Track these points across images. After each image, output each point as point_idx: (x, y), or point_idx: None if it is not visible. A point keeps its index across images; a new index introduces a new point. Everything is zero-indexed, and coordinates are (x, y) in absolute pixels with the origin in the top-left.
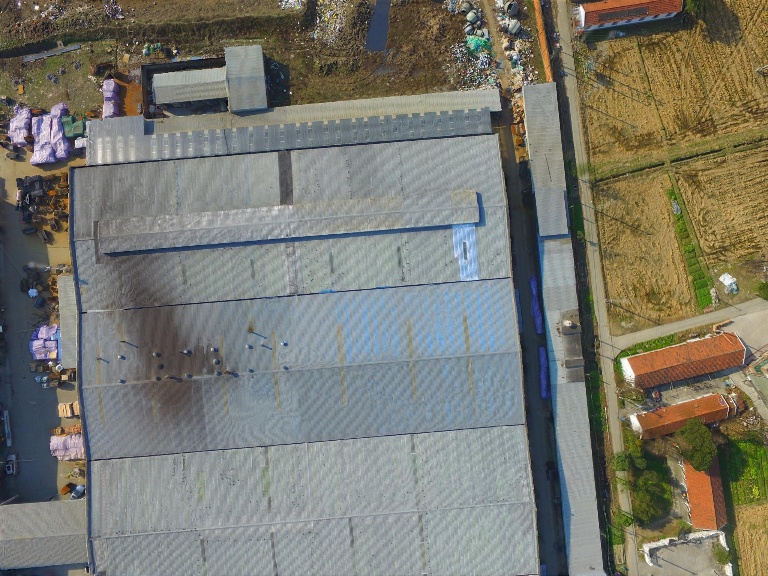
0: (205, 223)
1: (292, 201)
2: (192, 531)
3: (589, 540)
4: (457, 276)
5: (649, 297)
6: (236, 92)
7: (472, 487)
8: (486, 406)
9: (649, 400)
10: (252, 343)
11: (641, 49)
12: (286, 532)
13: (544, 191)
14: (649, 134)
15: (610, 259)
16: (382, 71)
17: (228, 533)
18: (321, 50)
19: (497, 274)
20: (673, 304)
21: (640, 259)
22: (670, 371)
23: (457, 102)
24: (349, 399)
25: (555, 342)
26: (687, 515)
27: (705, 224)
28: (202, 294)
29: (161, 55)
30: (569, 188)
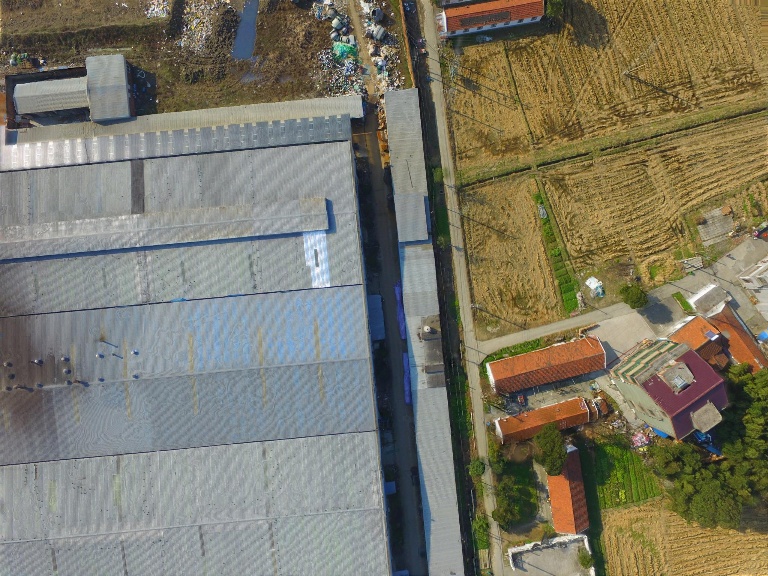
0: (54, 233)
1: (143, 210)
2: (42, 540)
3: (450, 545)
4: (309, 283)
5: (515, 301)
6: (97, 101)
7: (322, 494)
8: (337, 413)
9: (515, 404)
10: (103, 352)
11: (508, 53)
12: (136, 540)
13: (403, 197)
14: (516, 138)
15: (476, 264)
16: (249, 78)
17: (79, 542)
18: (188, 58)
19: (349, 281)
20: (539, 308)
21: (506, 264)
22: (530, 376)
23: (319, 109)
24: (201, 407)
25: (415, 348)
26: (552, 519)
27: (572, 228)
28: (54, 304)
29: (28, 65)
30: (434, 193)
